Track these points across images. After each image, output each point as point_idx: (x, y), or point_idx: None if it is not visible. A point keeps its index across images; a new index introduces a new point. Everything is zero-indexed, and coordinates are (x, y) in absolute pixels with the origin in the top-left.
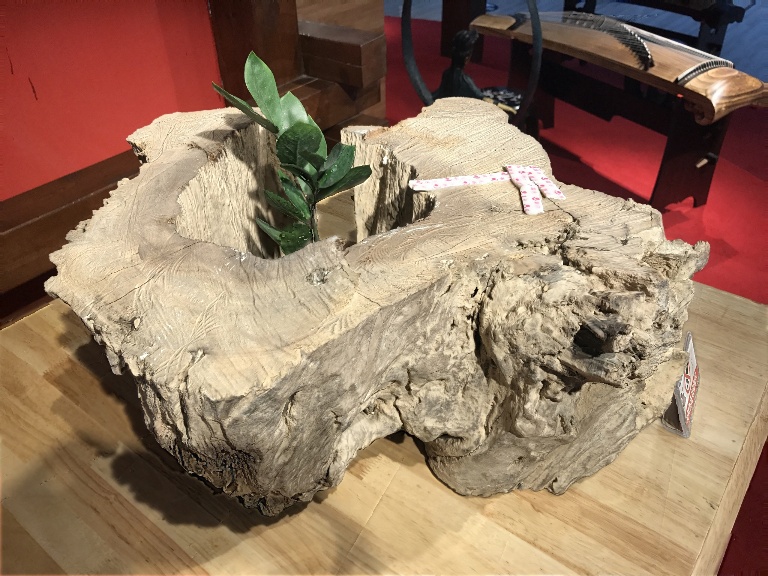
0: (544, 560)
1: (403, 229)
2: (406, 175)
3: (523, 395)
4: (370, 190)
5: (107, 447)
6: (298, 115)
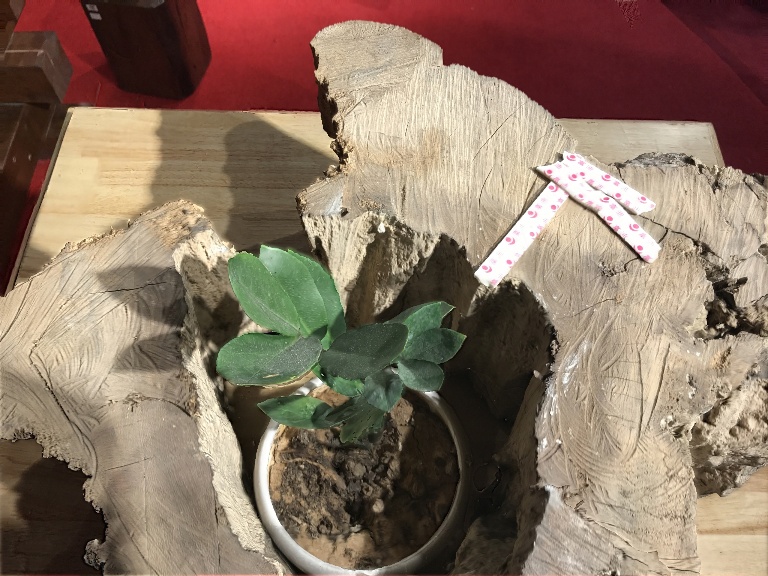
0: (717, 542)
1: (557, 382)
2: (432, 245)
3: (730, 471)
4: (352, 258)
5: None
6: (293, 273)
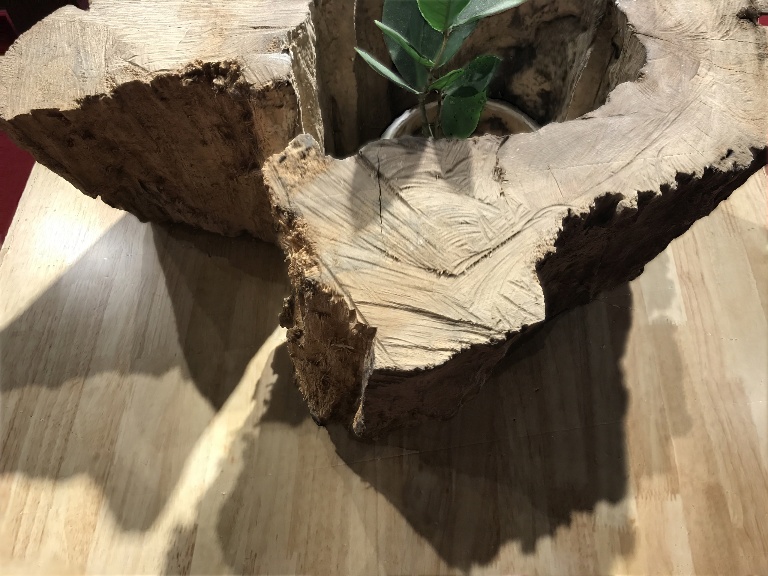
0: None
1: None
2: None
3: None
4: None
5: (664, 326)
6: None
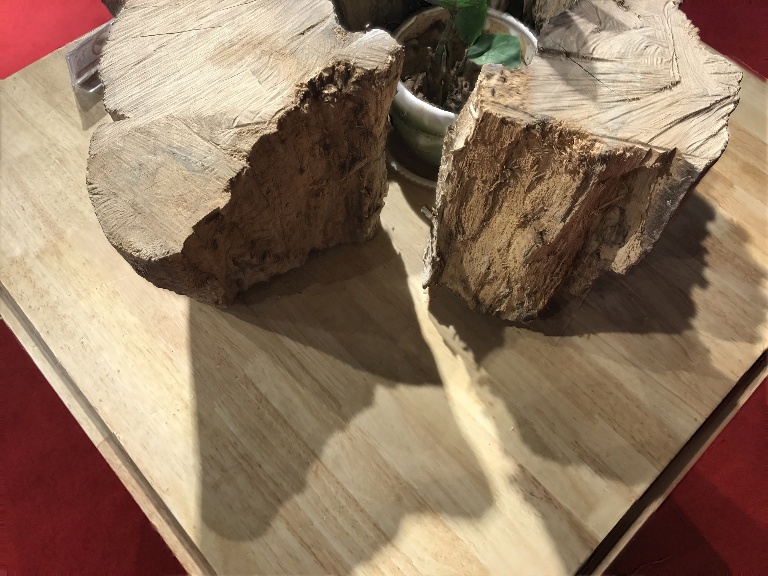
0: None
1: None
2: None
3: None
4: None
5: None
6: None
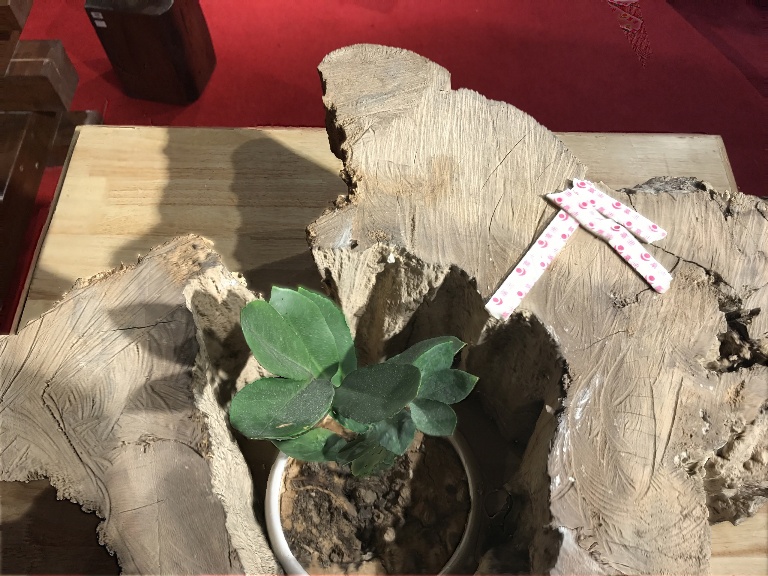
0: (729, 565)
1: (569, 417)
2: (442, 275)
3: (743, 501)
4: (362, 286)
5: None
6: (304, 312)
